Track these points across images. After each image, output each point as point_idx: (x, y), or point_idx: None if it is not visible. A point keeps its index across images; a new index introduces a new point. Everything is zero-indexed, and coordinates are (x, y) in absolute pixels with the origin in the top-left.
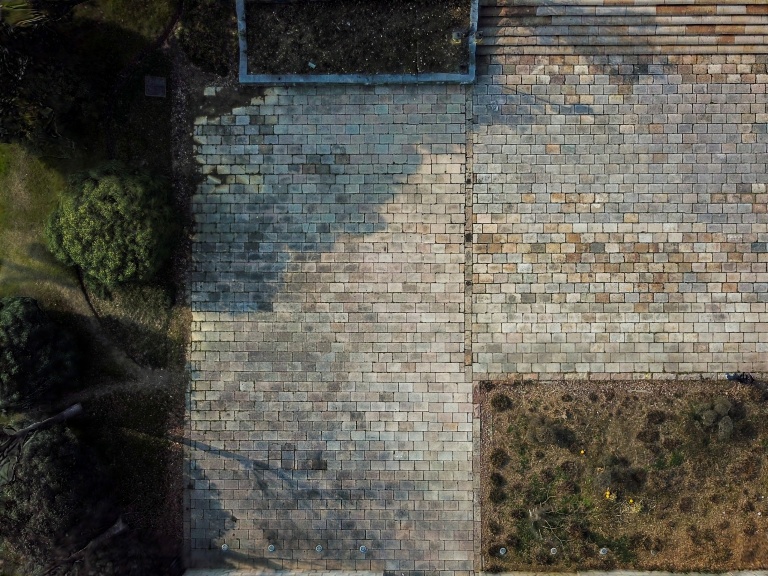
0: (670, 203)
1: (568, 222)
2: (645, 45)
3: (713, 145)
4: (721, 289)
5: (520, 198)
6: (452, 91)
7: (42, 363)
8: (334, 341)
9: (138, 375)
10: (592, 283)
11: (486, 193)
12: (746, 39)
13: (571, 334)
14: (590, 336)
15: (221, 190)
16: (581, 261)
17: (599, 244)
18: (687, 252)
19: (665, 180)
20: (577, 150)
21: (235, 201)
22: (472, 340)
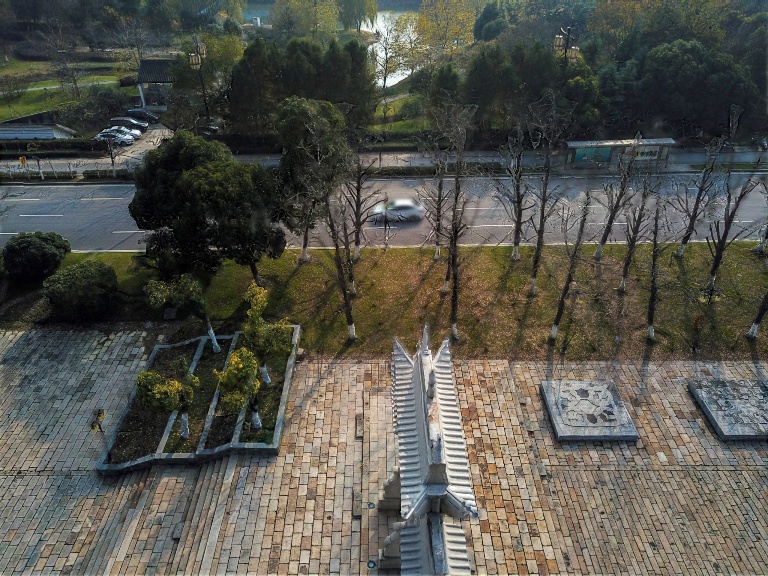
0: None
1: None
2: None
3: None
4: None
5: None
6: None
7: (17, 259)
8: None
9: (1, 309)
10: None
11: (2, 485)
12: None
13: None
14: None
15: (95, 343)
16: None
17: None
18: None
19: None
20: None
21: None
22: None
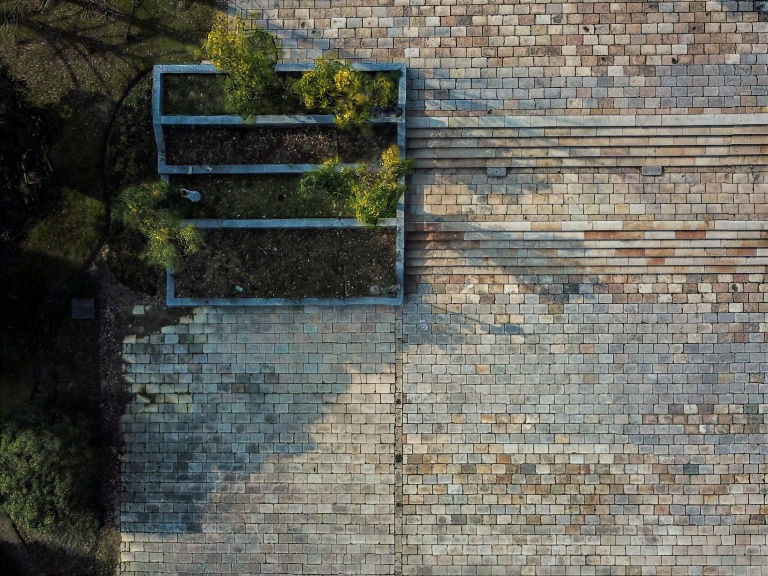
0: (601, 424)
1: (499, 443)
2: (575, 266)
3: (644, 365)
4: (653, 511)
5: (450, 418)
6: (381, 310)
7: None
8: (264, 562)
9: None
10: (523, 504)
11: (416, 413)
12: (676, 261)
13: (502, 556)
14: (521, 558)
15: (150, 409)
16: (512, 482)
17: (530, 465)
18: (619, 473)
19: (596, 400)
20: (507, 370)
21: (164, 420)
22: (402, 562)
